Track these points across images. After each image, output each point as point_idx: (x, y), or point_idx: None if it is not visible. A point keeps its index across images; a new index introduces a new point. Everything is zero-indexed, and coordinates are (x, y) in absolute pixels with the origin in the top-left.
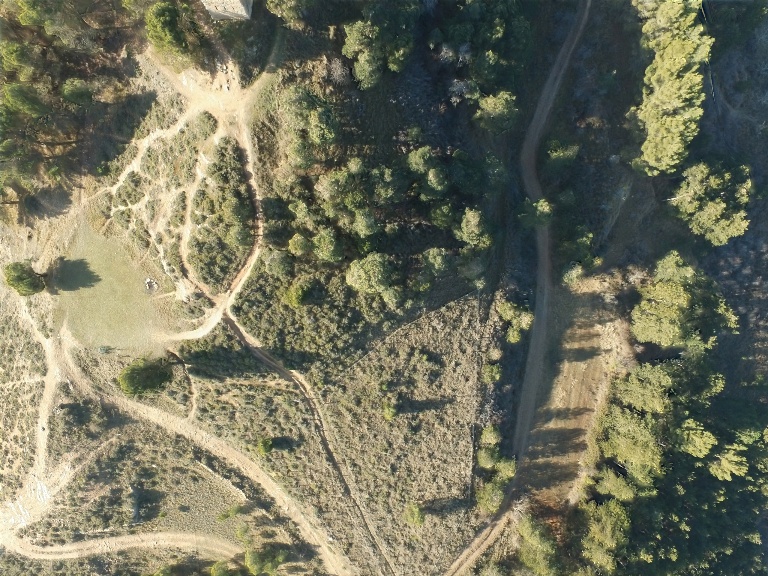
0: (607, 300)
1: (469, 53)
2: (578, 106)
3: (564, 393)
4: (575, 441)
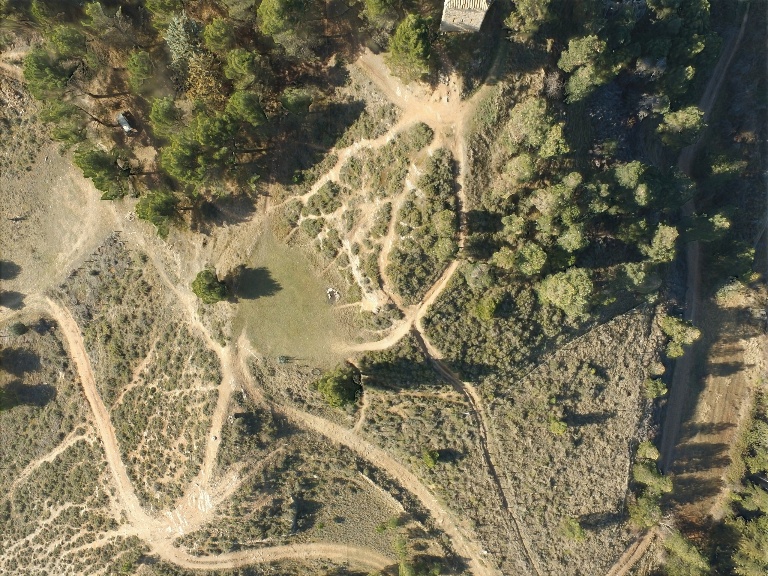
0: (757, 315)
1: (664, 68)
2: (733, 121)
3: (709, 408)
4: (718, 456)
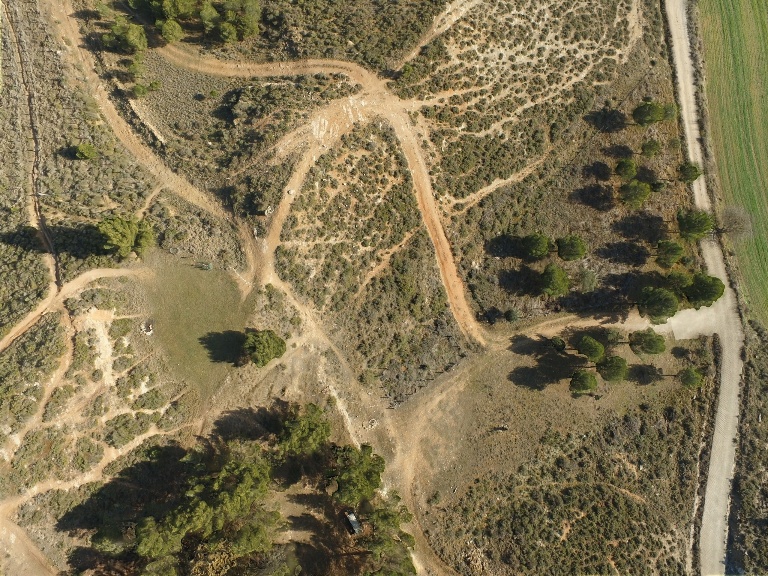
0: None
1: None
2: None
3: None
4: None
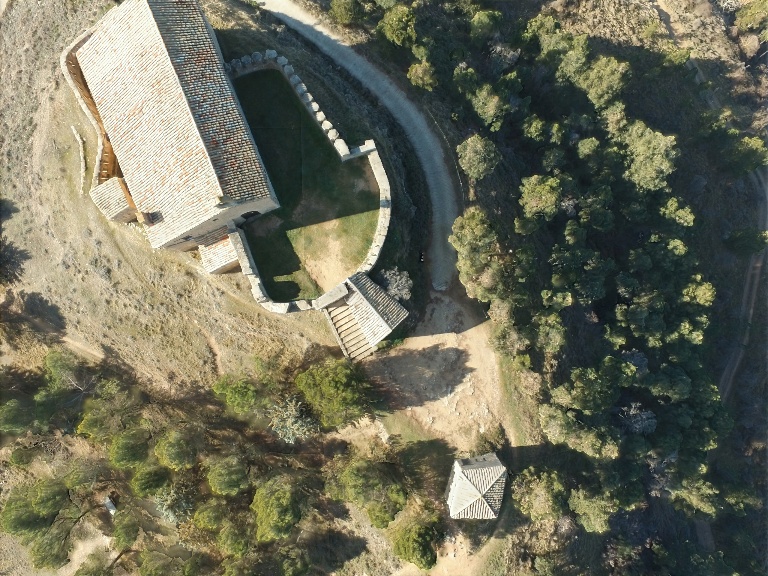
0: None
1: (676, 458)
2: (743, 431)
3: None
4: None
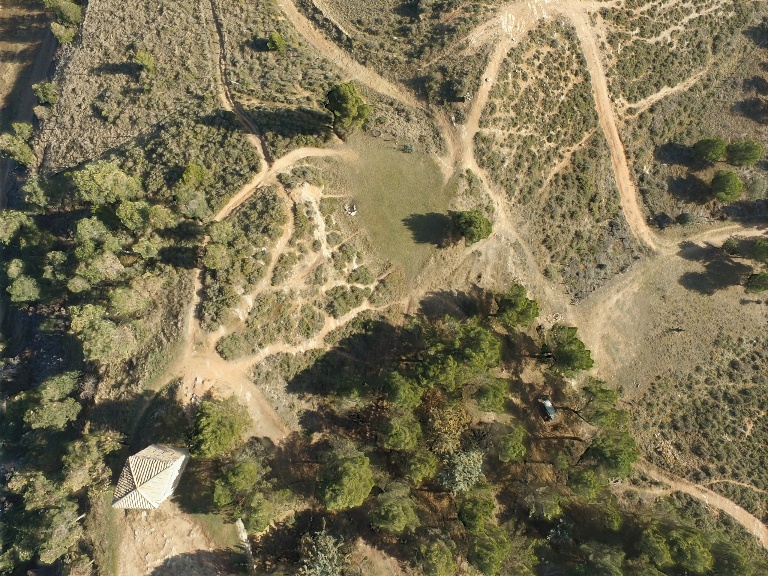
0: None
1: None
2: None
3: (4, 77)
4: (1, 29)
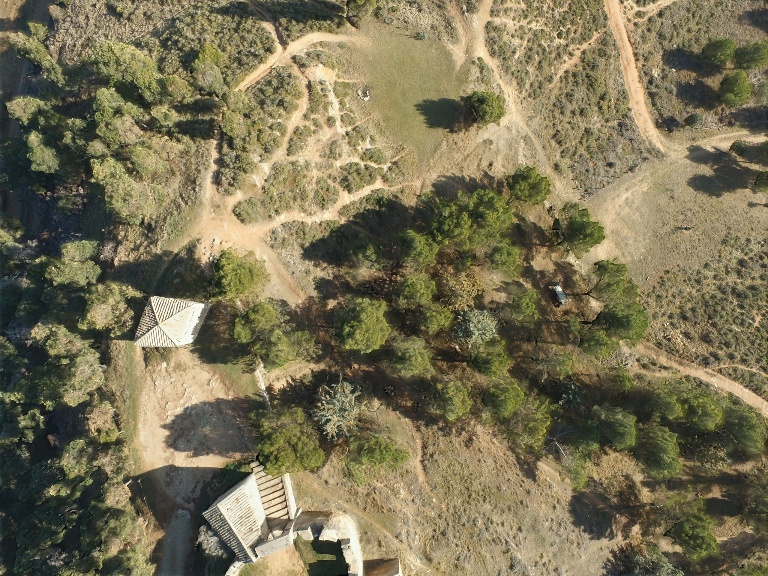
0: None
1: (3, 280)
2: None
3: None
4: None
